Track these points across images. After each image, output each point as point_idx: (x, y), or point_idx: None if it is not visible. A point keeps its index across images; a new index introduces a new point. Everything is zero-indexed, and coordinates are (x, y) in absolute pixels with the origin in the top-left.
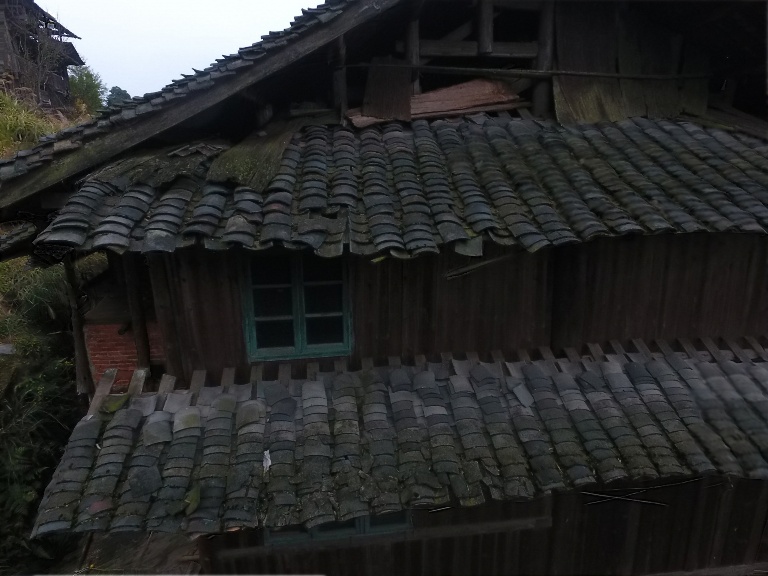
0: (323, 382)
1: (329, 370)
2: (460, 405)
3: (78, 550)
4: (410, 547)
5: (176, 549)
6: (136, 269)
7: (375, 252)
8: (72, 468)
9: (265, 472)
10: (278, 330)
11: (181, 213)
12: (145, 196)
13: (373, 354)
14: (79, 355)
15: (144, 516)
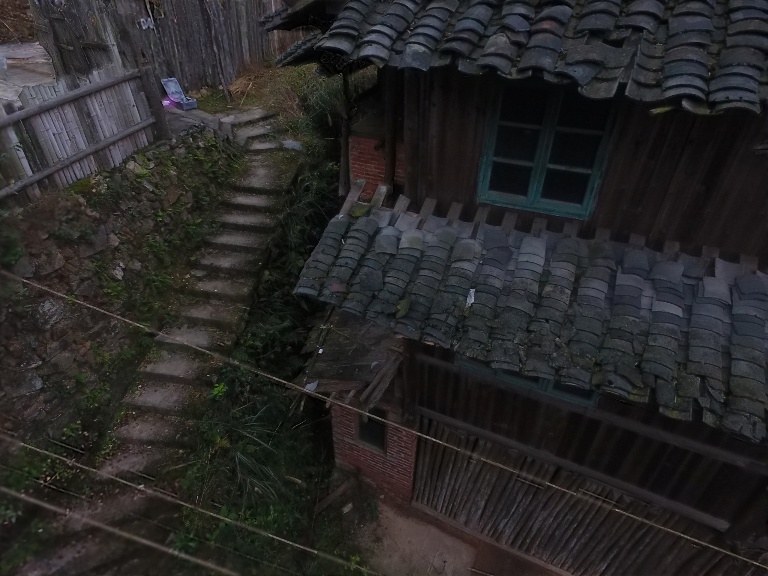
0: (546, 241)
1: (556, 230)
2: (704, 312)
3: (325, 312)
4: (587, 422)
5: (388, 338)
6: (396, 87)
7: (660, 99)
8: (324, 253)
9: (467, 307)
10: (514, 175)
11: (443, 26)
12: (412, 4)
13: (613, 226)
14: (343, 162)
15: (366, 306)
